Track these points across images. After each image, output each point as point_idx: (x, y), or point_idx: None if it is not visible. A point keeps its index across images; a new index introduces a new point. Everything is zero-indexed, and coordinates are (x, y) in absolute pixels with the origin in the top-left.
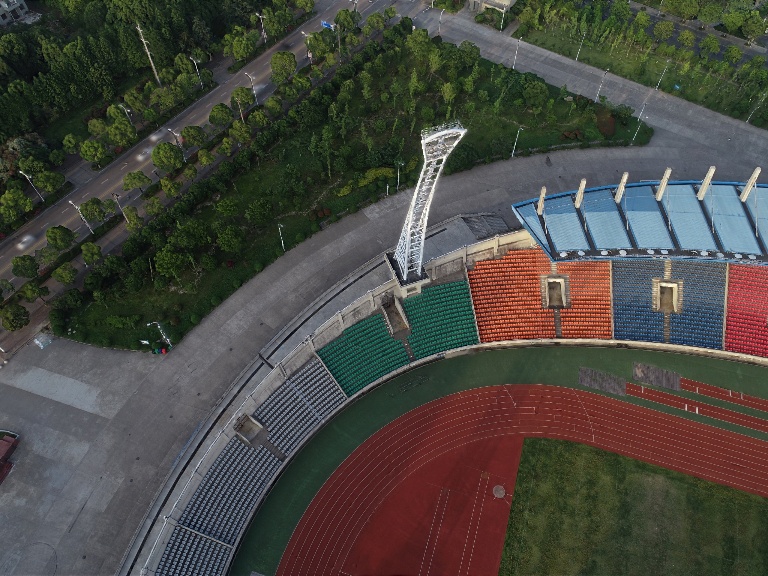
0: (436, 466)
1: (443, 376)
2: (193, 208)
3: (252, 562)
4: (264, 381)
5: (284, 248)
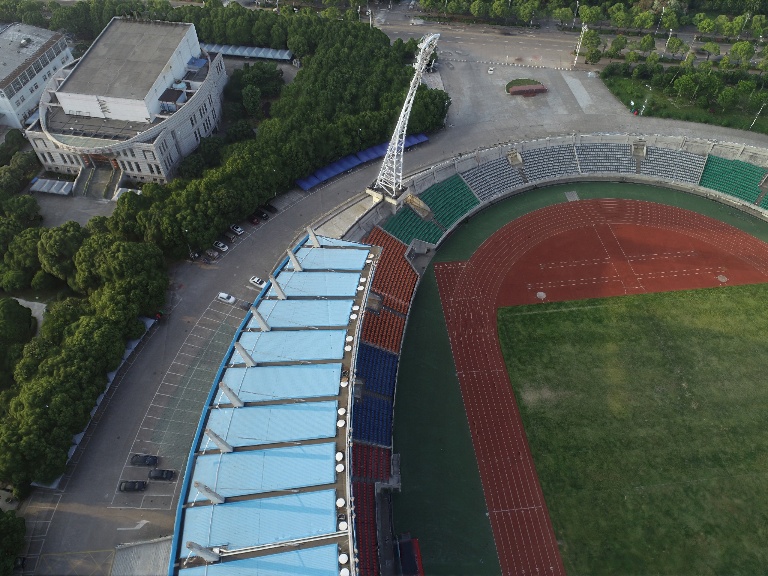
0: (704, 244)
1: (762, 230)
2: (725, 83)
3: (579, 189)
4: (670, 137)
5: (751, 128)
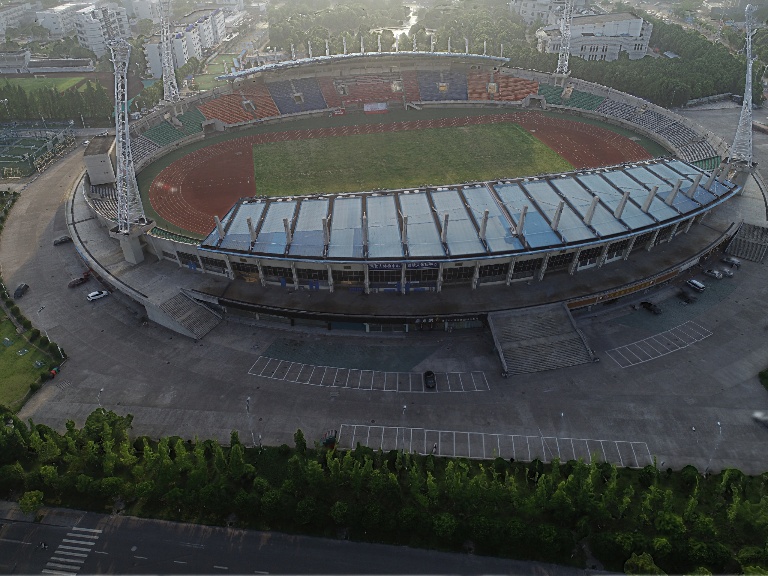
0: None
1: None
2: None
3: None
4: None
5: None
